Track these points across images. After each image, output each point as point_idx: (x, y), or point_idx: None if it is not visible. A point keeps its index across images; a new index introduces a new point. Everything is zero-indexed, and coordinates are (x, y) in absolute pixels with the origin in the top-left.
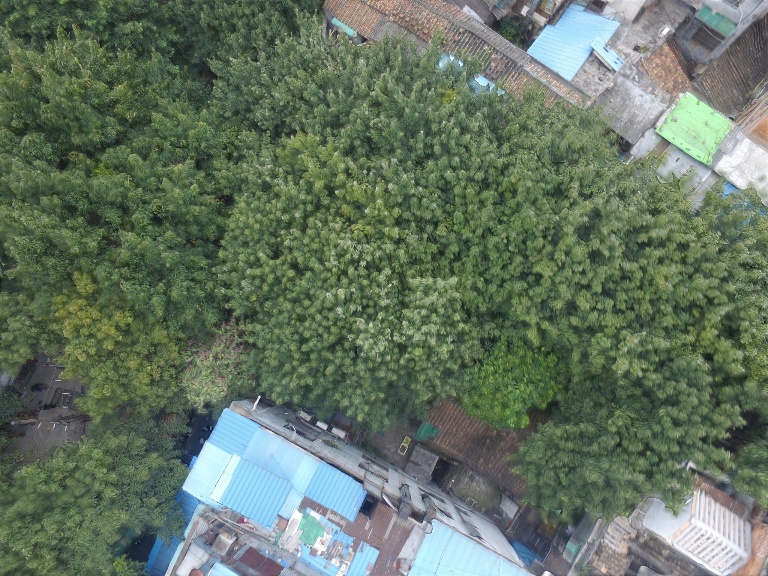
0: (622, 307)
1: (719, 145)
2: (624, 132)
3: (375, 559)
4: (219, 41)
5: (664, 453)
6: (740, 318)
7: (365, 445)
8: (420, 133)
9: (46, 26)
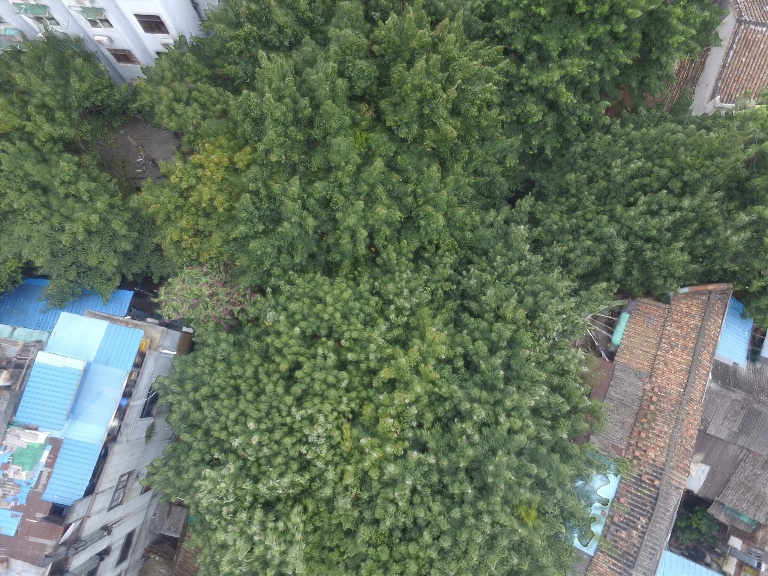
0: None
1: None
2: None
3: (6, 533)
4: (562, 194)
5: None
6: None
7: None
8: (470, 488)
9: (504, 32)
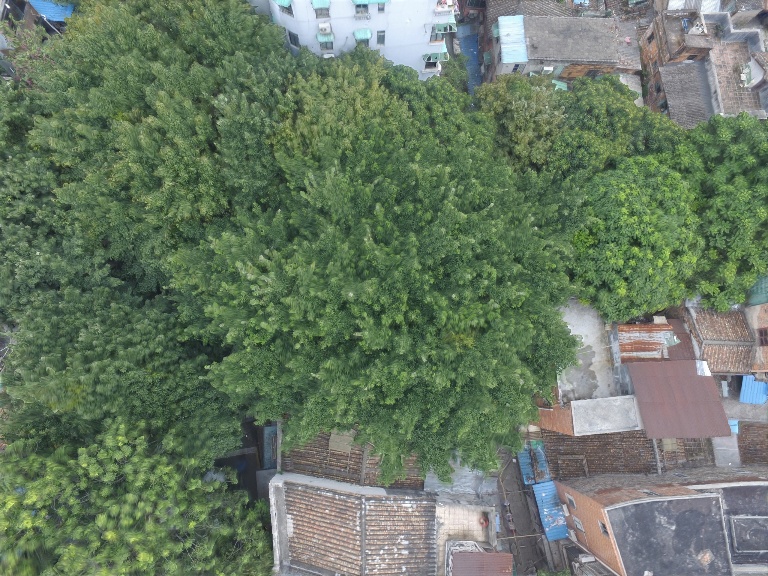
0: None
1: None
2: None
3: None
4: None
5: None
6: None
7: None
8: None
9: None
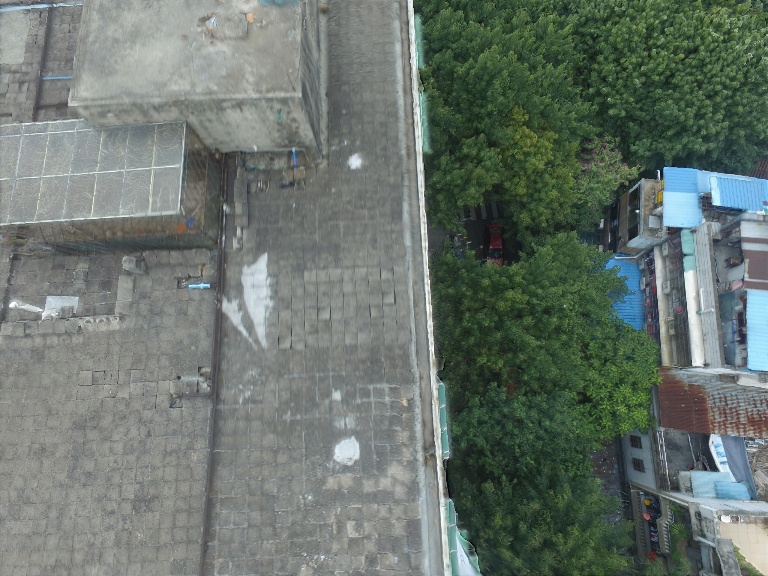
0: None
1: None
2: None
3: None
4: None
5: None
6: None
7: None
8: None
9: None
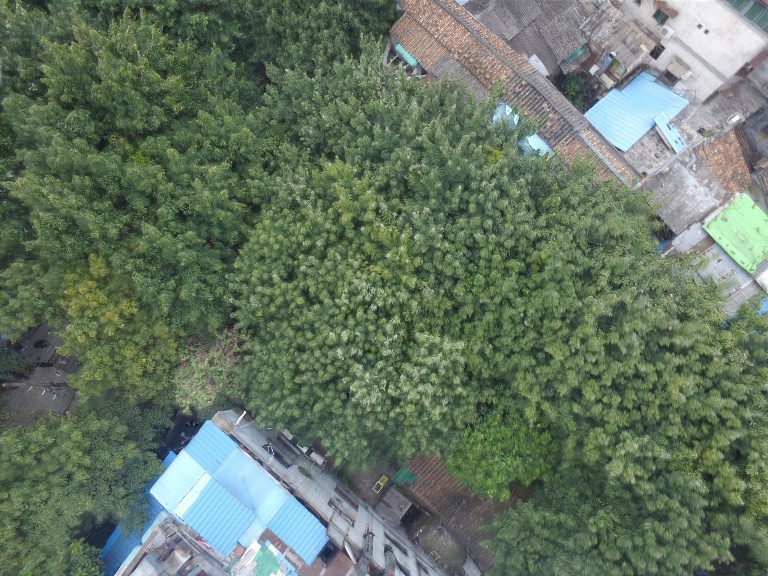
0: (629, 405)
1: (766, 255)
2: (669, 220)
3: None
4: (281, 45)
5: (641, 569)
6: (750, 446)
7: (341, 475)
8: (458, 188)
9: (115, 4)
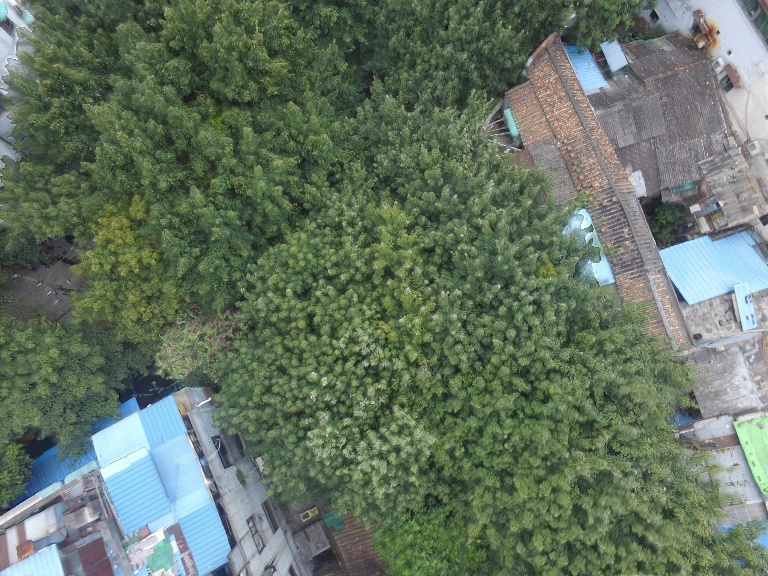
0: (574, 572)
1: None
2: (702, 399)
3: None
4: (397, 64)
5: None
6: None
7: None
8: (498, 285)
9: None
